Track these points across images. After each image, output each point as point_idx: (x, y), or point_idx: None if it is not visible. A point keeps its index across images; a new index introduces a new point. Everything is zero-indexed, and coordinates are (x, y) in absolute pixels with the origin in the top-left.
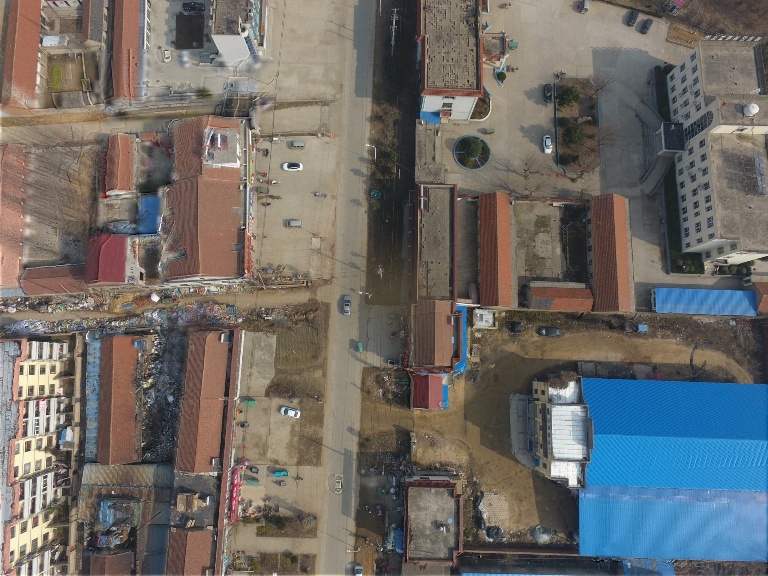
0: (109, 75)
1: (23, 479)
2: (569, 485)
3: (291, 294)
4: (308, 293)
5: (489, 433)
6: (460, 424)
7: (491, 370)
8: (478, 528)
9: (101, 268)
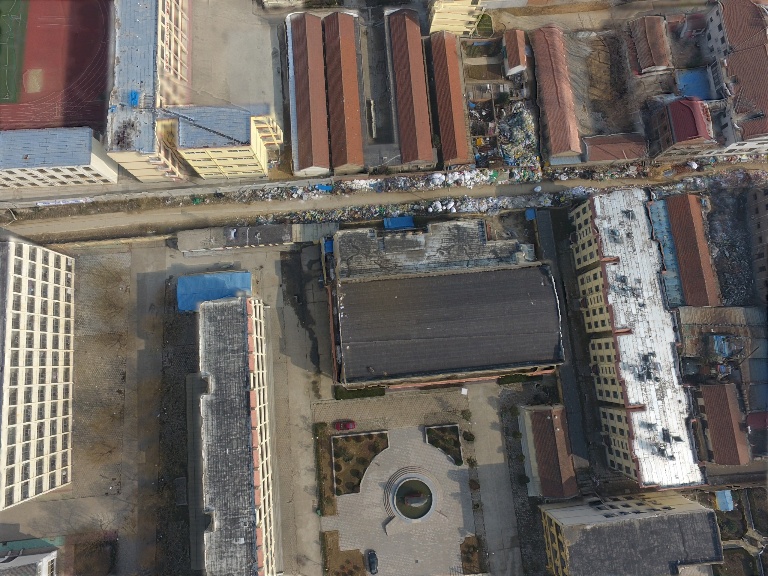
0: None
1: None
2: None
3: None
4: None
5: None
6: None
7: None
8: None
9: (697, 125)
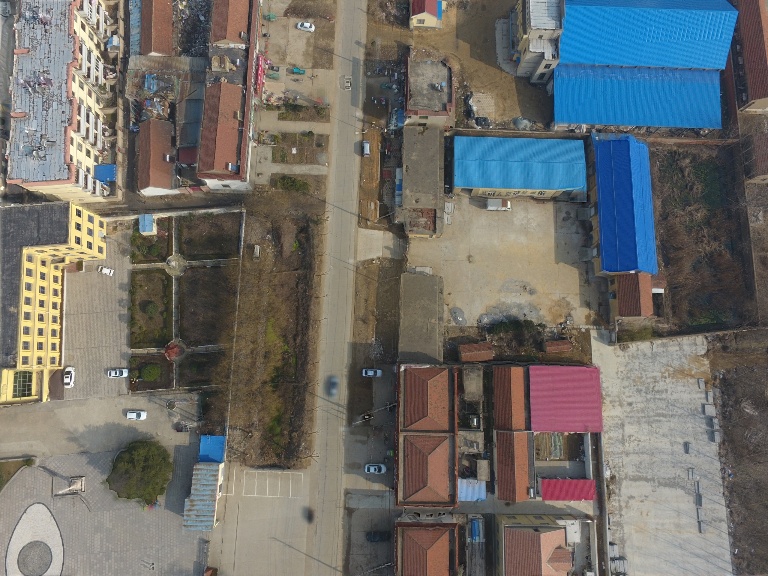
0: None
1: (81, 42)
2: (545, 59)
3: None
4: None
5: (478, 49)
6: (453, 42)
7: (479, 2)
8: (468, 118)
9: None
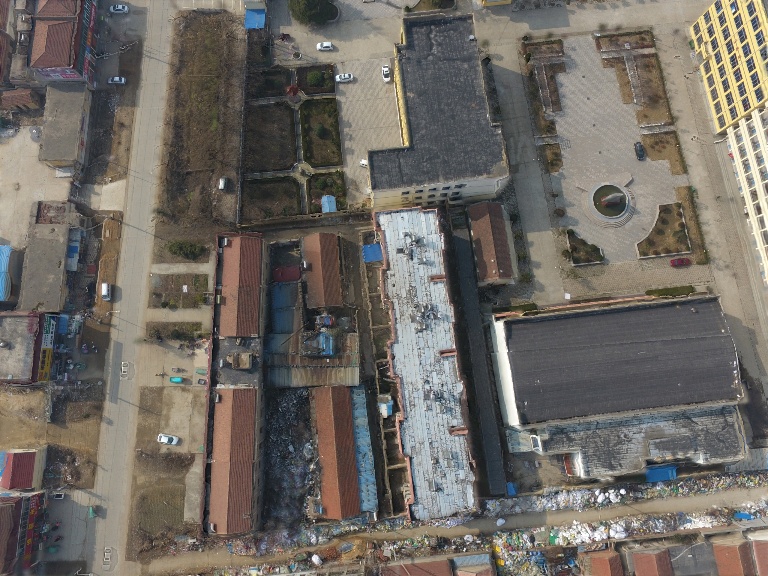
0: None
1: None
2: None
3: (170, 569)
4: (151, 571)
5: None
6: (1, 432)
7: None
8: None
9: None
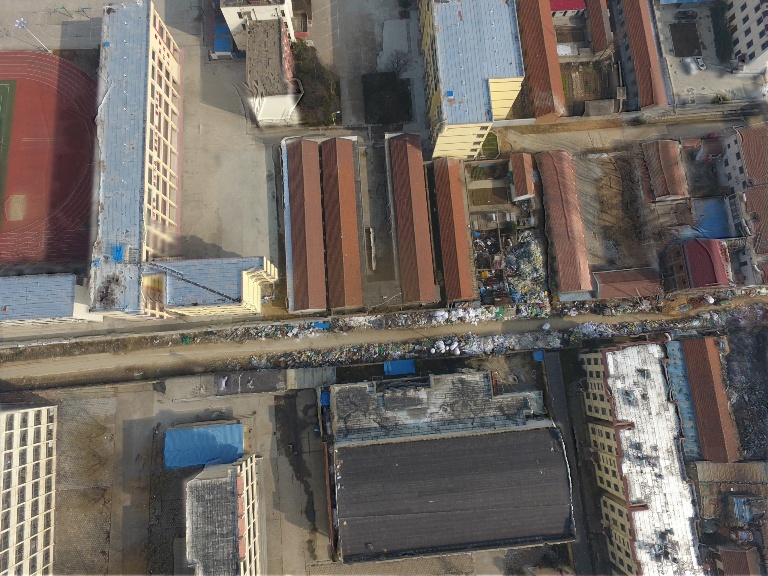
0: (649, 83)
1: None
2: None
3: None
4: None
5: None
6: None
7: None
8: None
9: (716, 272)
